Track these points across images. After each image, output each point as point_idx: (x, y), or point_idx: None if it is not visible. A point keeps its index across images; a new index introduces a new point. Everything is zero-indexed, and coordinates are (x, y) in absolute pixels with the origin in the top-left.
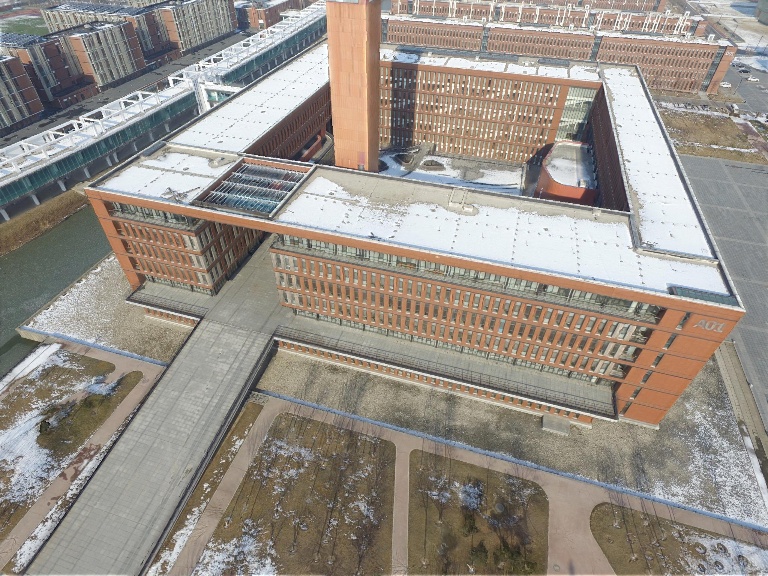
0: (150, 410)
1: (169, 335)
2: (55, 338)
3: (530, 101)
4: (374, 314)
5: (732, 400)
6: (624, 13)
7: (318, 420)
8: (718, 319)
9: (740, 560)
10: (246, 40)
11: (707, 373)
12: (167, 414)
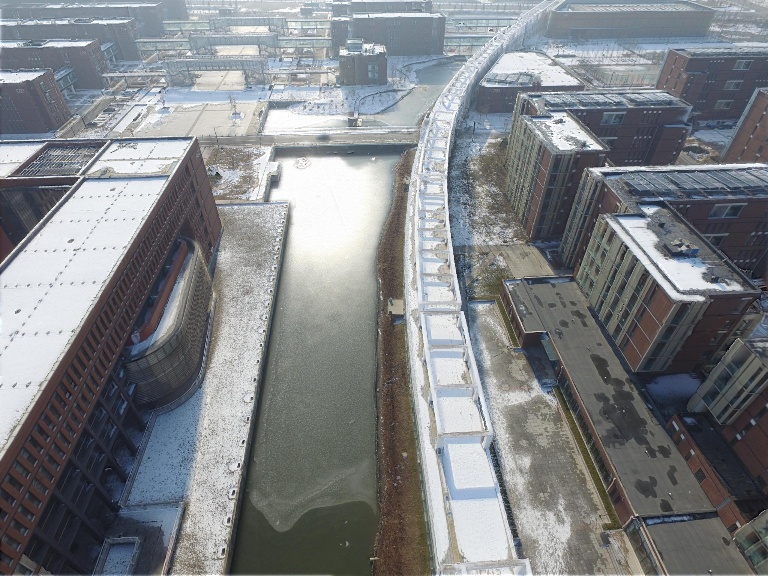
0: None
1: None
2: (257, 201)
3: None
4: None
5: None
6: None
7: None
8: None
9: None
10: None
11: None
12: None
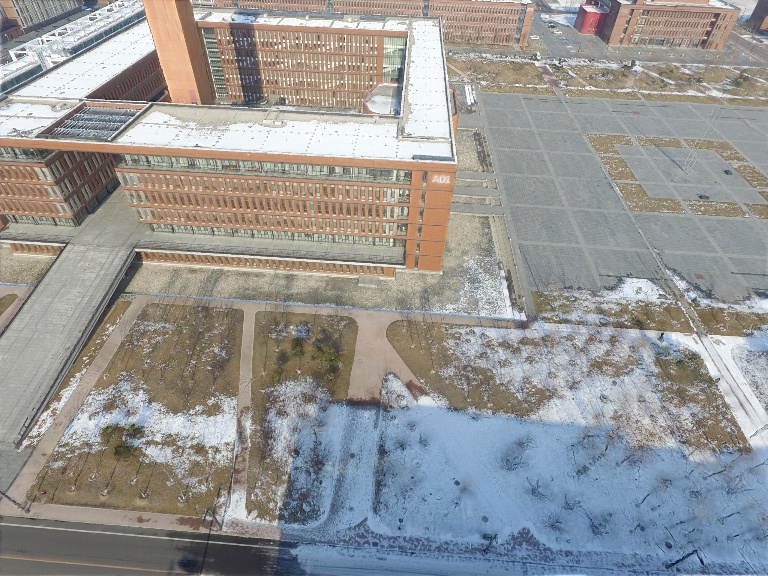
0: (27, 314)
1: (40, 266)
2: None
3: (355, 52)
4: (216, 216)
5: (496, 250)
6: None
7: (180, 304)
8: (444, 173)
9: (482, 336)
10: (92, 14)
11: (483, 237)
12: (43, 314)
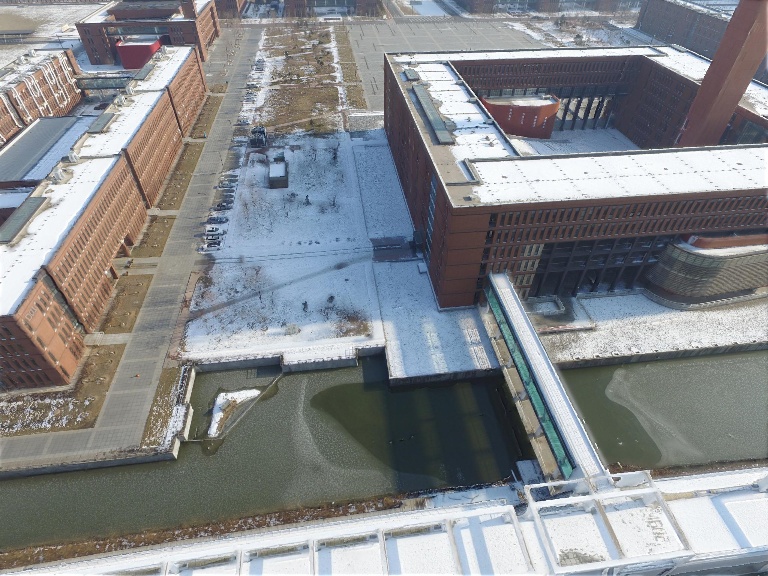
0: None
1: None
2: None
3: None
4: None
5: None
6: (9, 79)
7: None
8: None
9: None
10: None
11: None
12: None
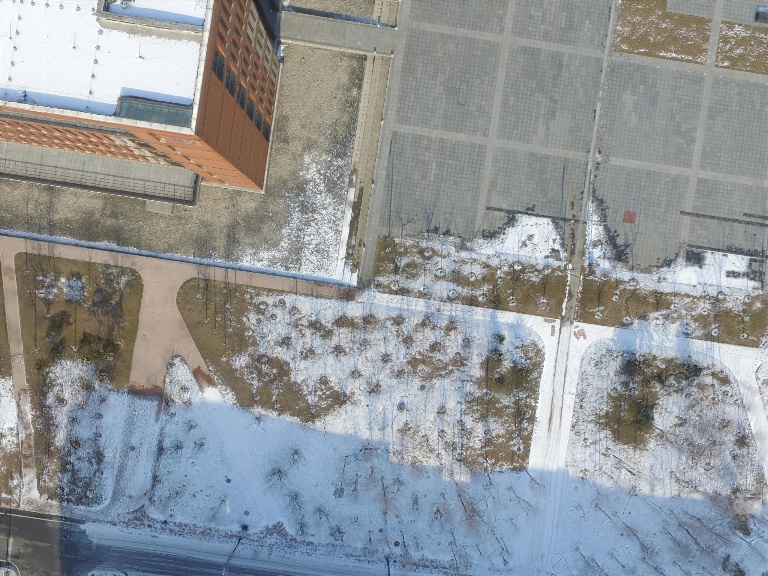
0: None
1: None
2: None
3: None
4: None
5: (356, 144)
6: None
7: None
8: None
9: (293, 310)
10: None
11: (344, 109)
12: None
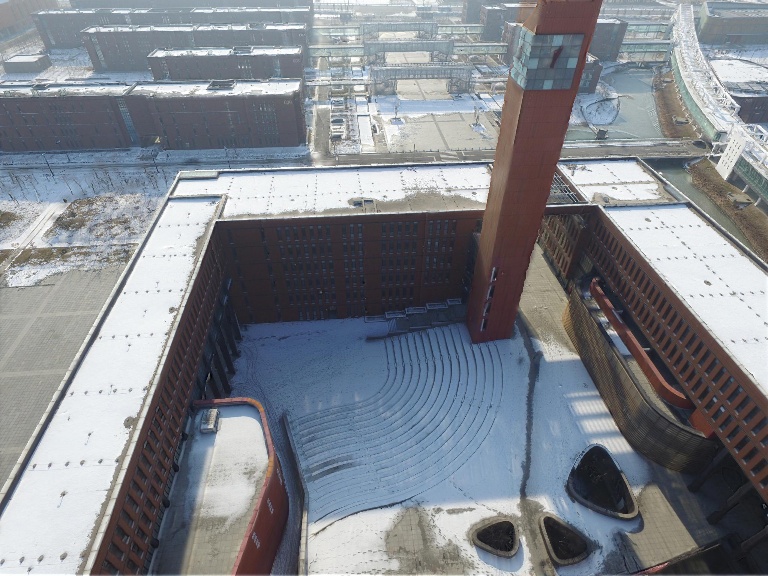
0: None
1: None
2: None
3: None
4: None
5: None
6: None
7: None
8: None
9: None
10: None
11: None
12: None
